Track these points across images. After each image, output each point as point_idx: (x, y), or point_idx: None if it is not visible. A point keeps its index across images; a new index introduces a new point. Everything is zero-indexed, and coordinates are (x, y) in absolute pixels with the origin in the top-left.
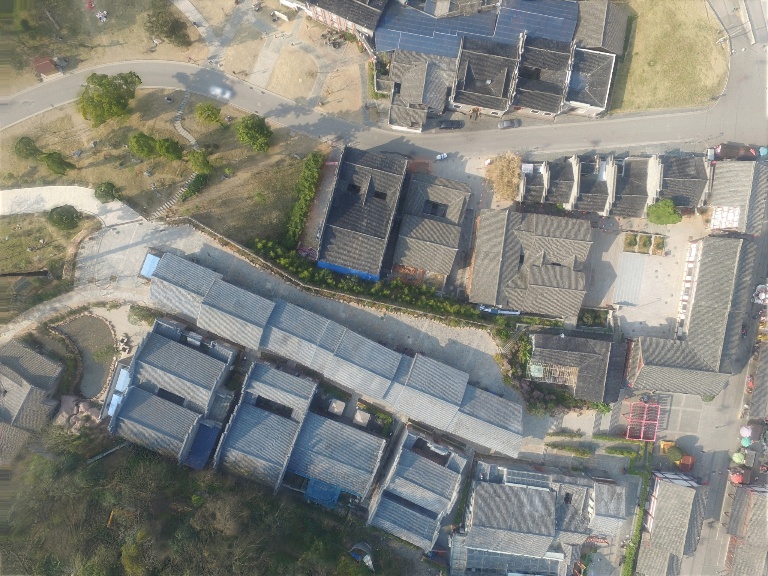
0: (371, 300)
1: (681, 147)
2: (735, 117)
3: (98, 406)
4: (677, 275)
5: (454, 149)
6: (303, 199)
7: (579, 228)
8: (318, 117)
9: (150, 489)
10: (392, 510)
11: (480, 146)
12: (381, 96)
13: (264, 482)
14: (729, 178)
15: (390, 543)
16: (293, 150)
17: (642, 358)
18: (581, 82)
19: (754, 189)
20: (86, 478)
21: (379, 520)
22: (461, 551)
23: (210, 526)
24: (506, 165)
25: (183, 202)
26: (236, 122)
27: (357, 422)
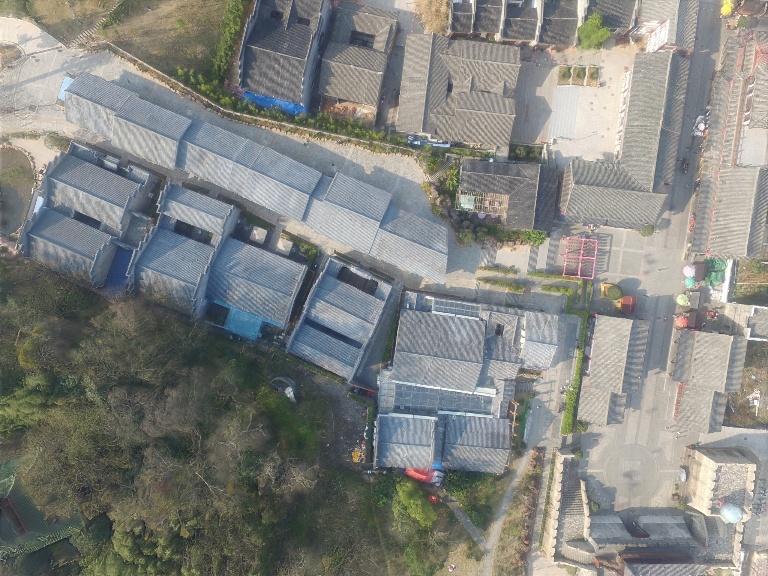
0: (293, 125)
1: None
2: None
3: (16, 240)
4: (613, 107)
5: None
6: (228, 32)
7: (508, 53)
8: None
9: (63, 315)
10: (313, 336)
11: None
12: None
13: (182, 310)
14: None
15: (315, 378)
16: None
17: (572, 179)
18: None
19: (684, 1)
20: None
21: (299, 345)
22: (389, 387)
23: (113, 328)
24: None
25: None
26: None
27: (279, 250)
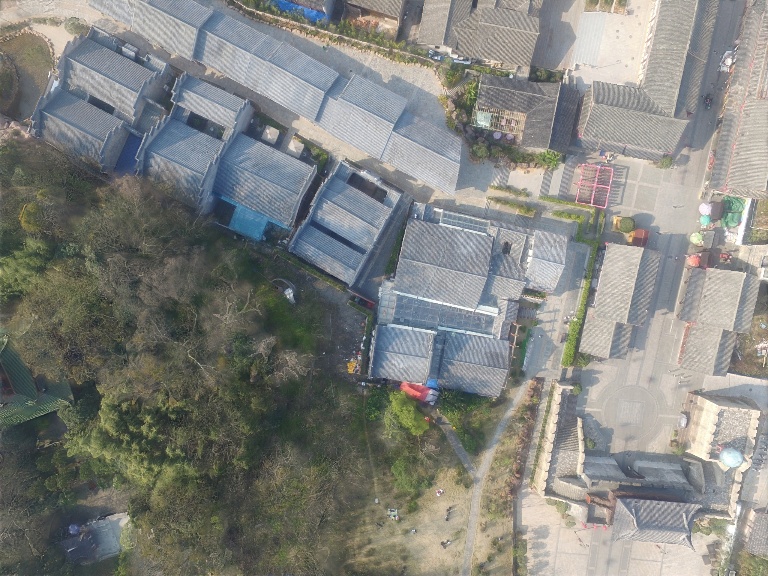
0: (314, 27)
1: None
2: None
3: (29, 124)
4: (639, 37)
5: None
6: None
7: None
8: None
9: (70, 197)
10: (318, 238)
11: None
12: None
13: (188, 202)
14: None
15: (316, 284)
16: None
17: (593, 98)
18: None
19: None
20: (0, 159)
21: (303, 245)
22: (390, 299)
23: (117, 201)
24: None
25: None
26: None
27: (290, 151)
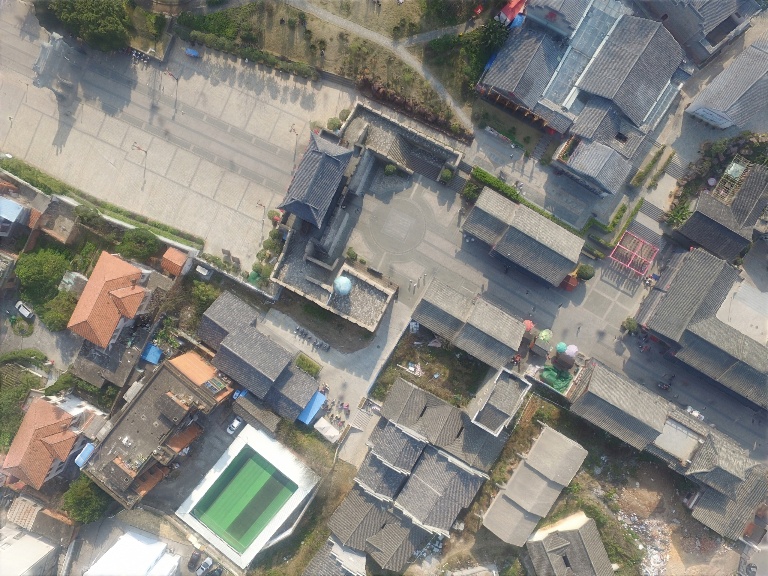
0: None
1: None
2: None
3: None
4: None
5: None
6: None
7: None
8: None
9: None
10: None
11: None
12: None
13: None
14: None
15: None
16: None
17: None
18: None
19: None
20: None
21: None
22: (613, 11)
23: None
24: None
25: None
26: None
27: None
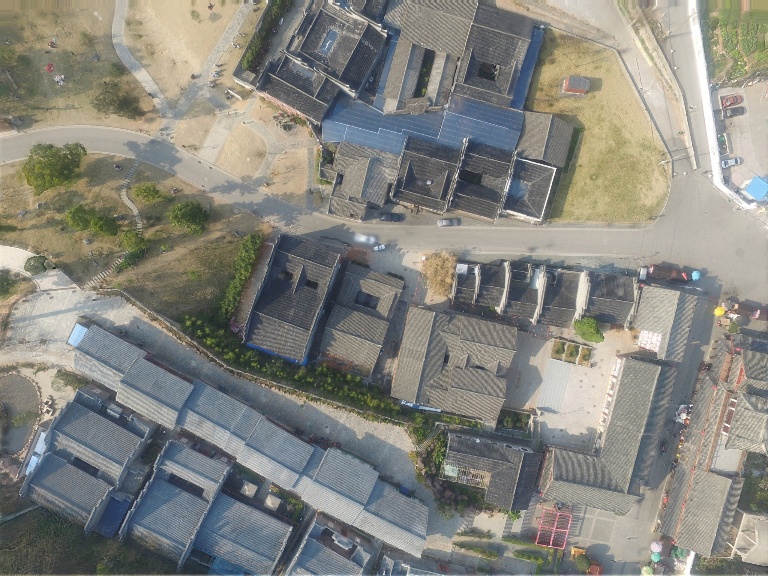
0: (292, 388)
1: (616, 262)
2: (672, 238)
3: (18, 464)
4: (601, 387)
5: (393, 241)
6: (238, 278)
7: (505, 335)
8: (262, 197)
9: None
10: None
11: (419, 240)
12: (325, 183)
13: (170, 557)
14: (654, 304)
15: None
16: (234, 228)
17: (553, 472)
18: (521, 190)
19: (678, 317)
20: None
21: None
22: None
23: None
24: (440, 264)
25: (118, 273)
26: (181, 195)
27: (267, 506)
